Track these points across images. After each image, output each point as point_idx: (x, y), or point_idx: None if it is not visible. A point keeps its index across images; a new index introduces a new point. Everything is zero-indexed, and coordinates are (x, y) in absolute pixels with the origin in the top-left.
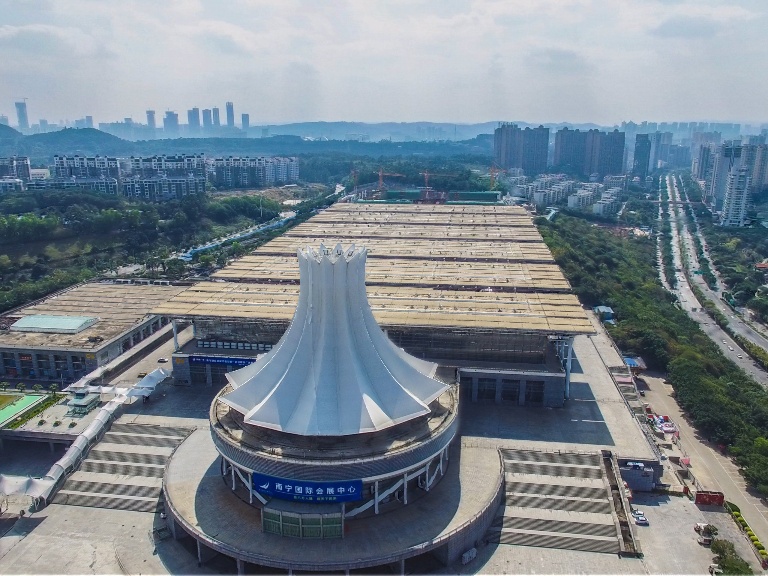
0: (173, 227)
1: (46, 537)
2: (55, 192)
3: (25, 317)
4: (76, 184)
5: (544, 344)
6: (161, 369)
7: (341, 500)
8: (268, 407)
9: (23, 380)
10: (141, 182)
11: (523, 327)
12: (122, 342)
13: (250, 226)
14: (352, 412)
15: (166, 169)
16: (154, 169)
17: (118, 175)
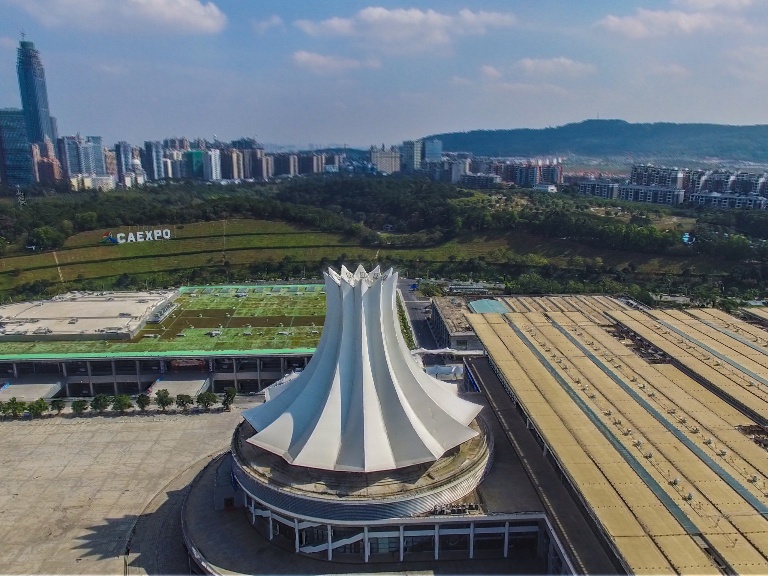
0: None
1: None
2: (762, 213)
3: (485, 299)
4: None
5: None
6: (456, 367)
7: None
8: None
9: (434, 340)
10: None
11: (598, 506)
12: None
13: None
14: None
15: None
16: None
17: None
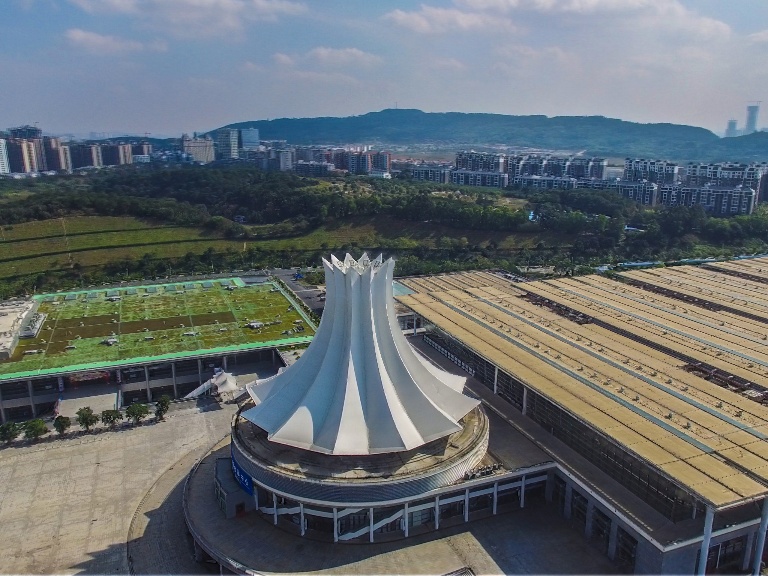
0: (641, 238)
1: (203, 418)
2: (580, 192)
3: None
4: (617, 186)
5: (676, 489)
6: None
7: (243, 487)
8: (267, 385)
9: None
10: (679, 190)
11: (630, 444)
12: (409, 320)
13: (756, 253)
14: (288, 417)
15: (720, 178)
16: (708, 177)
17: (673, 181)
